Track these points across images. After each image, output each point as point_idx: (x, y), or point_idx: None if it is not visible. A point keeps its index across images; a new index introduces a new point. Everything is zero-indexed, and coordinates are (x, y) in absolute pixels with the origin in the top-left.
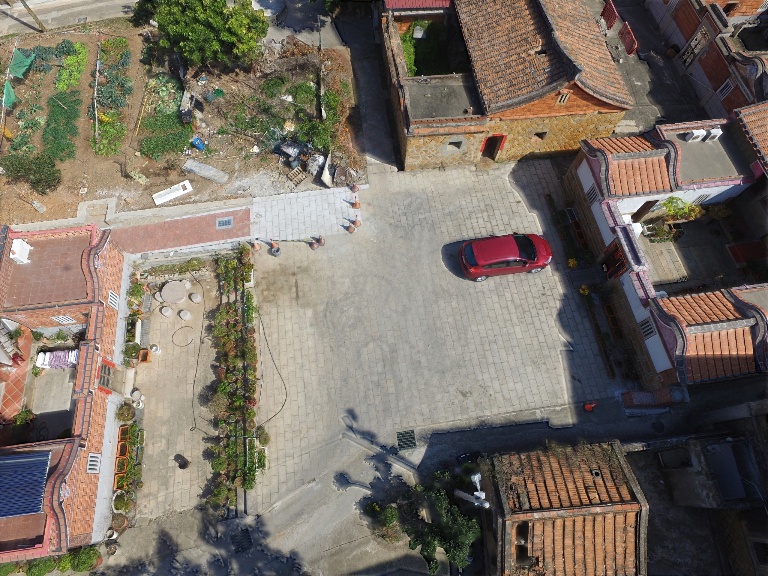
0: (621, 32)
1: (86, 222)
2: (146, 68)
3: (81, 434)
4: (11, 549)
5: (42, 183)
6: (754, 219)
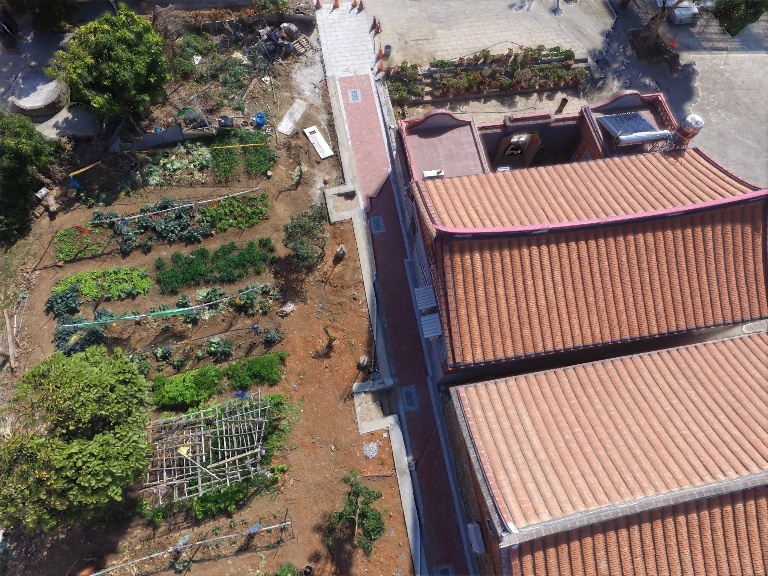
0: None
1: None
2: (129, 190)
3: None
4: (663, 125)
5: None
6: None
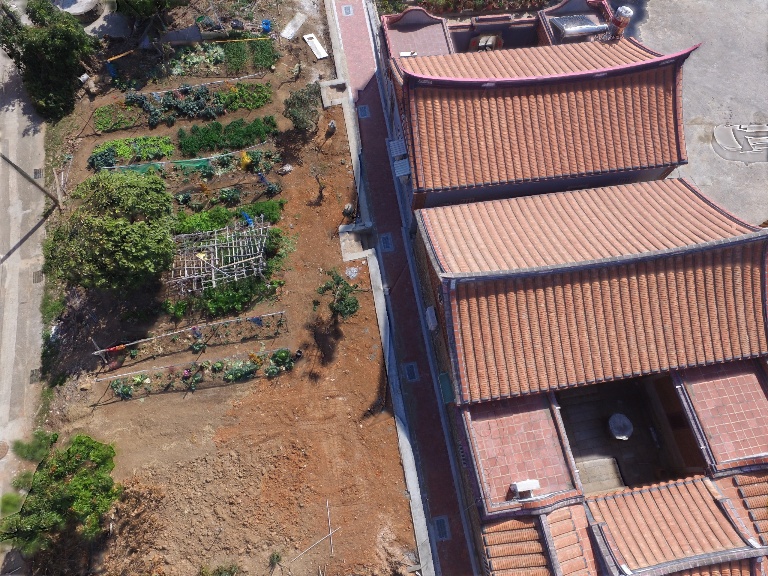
0: None
1: None
2: (155, 78)
3: None
4: None
5: None
6: None
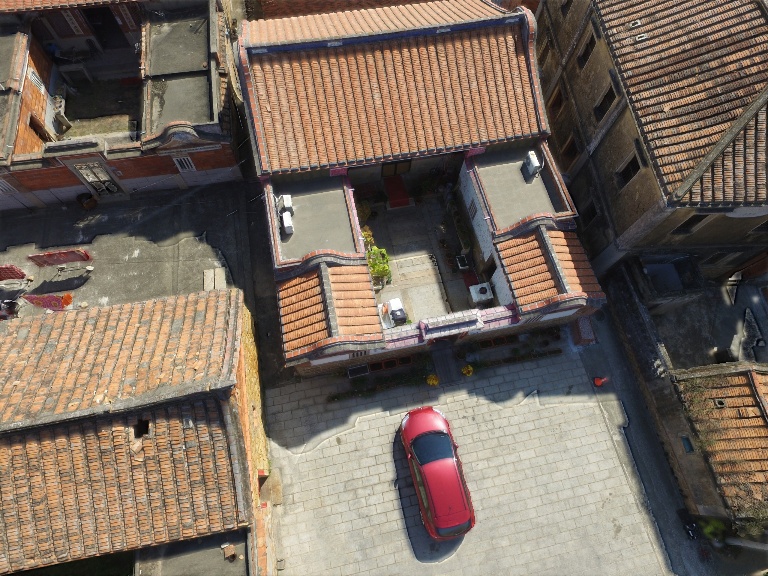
0: (41, 263)
1: None
2: None
3: None
4: None
5: None
6: (361, 178)
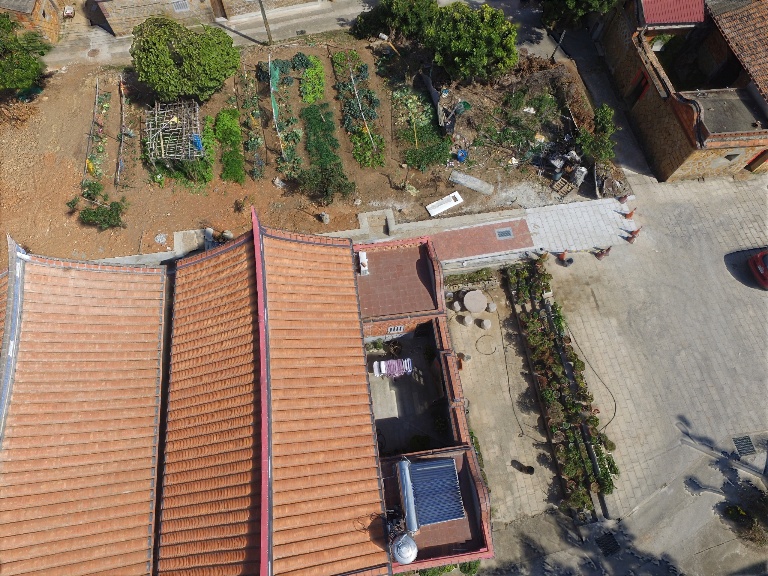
0: None
1: (369, 233)
2: (387, 81)
3: (467, 441)
4: (447, 553)
5: (330, 195)
6: None
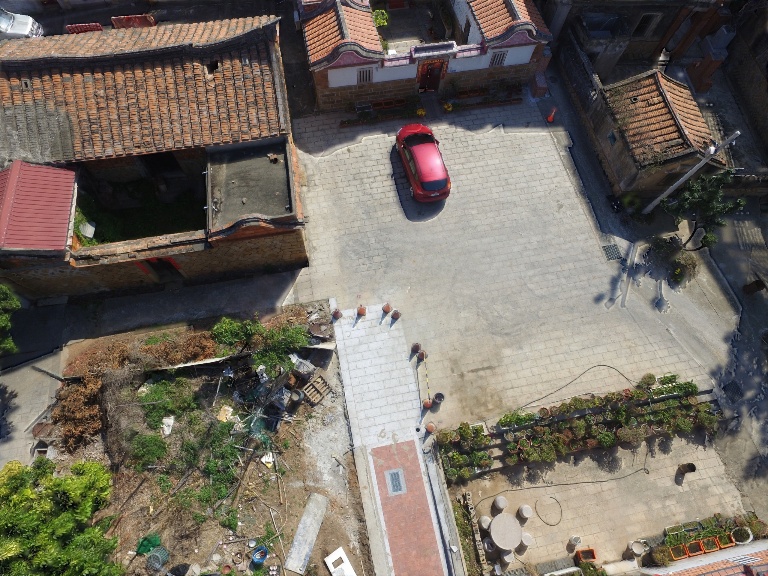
0: None
1: None
2: None
3: (742, 573)
4: None
5: None
6: None
